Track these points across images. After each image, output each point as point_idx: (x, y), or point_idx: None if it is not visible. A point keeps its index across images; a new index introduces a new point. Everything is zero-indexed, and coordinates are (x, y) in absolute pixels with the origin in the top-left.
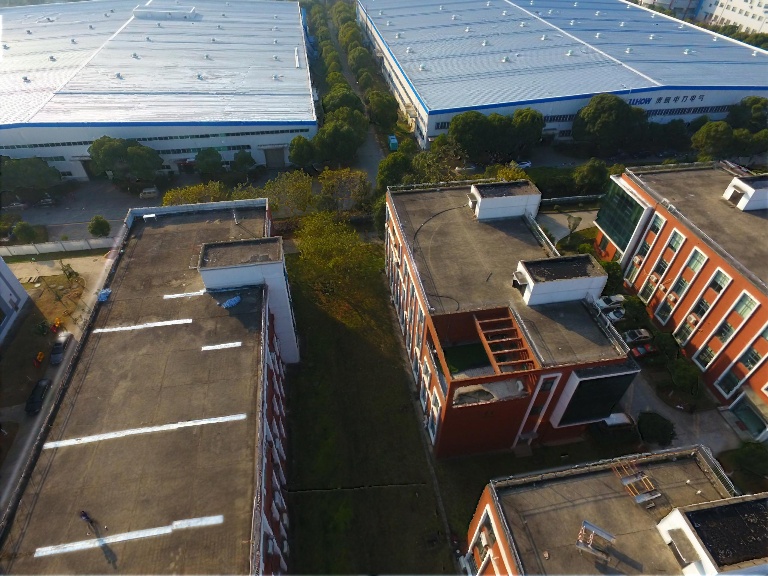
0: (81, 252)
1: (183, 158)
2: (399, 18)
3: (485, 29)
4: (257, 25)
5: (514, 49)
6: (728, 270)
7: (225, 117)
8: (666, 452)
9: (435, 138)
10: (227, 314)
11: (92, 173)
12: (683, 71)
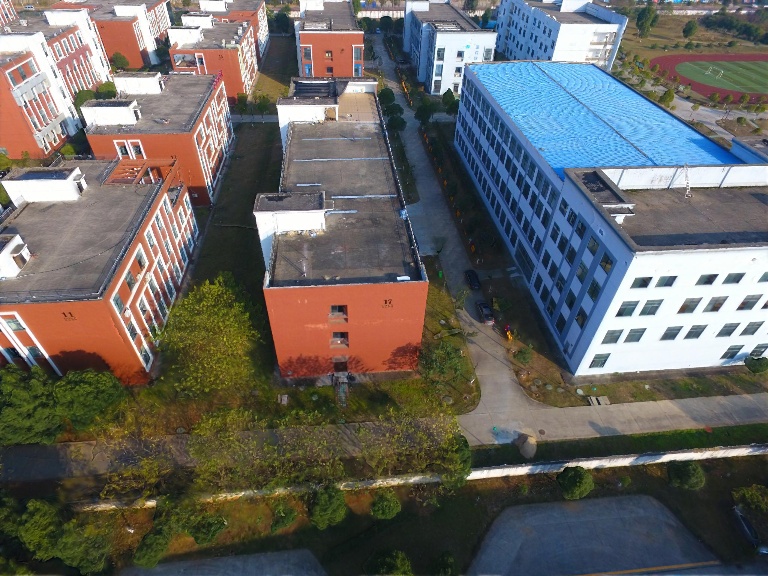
0: (579, 457)
1: None
2: None
3: None
4: None
5: None
6: None
7: None
8: None
9: None
10: None
11: None
12: None
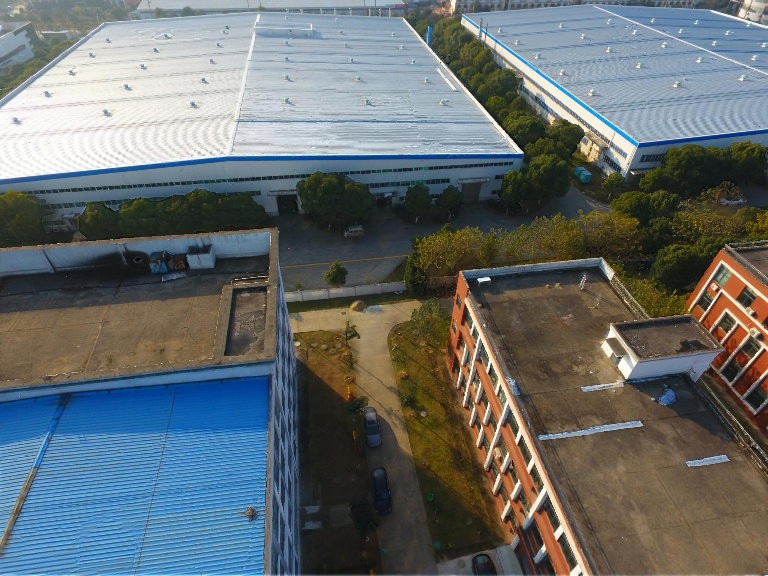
0: (321, 302)
1: (380, 192)
2: (523, 36)
3: (625, 50)
4: (381, 43)
5: (676, 73)
6: None
7: (427, 149)
8: None
9: (638, 171)
10: (675, 414)
11: (281, 207)
12: None
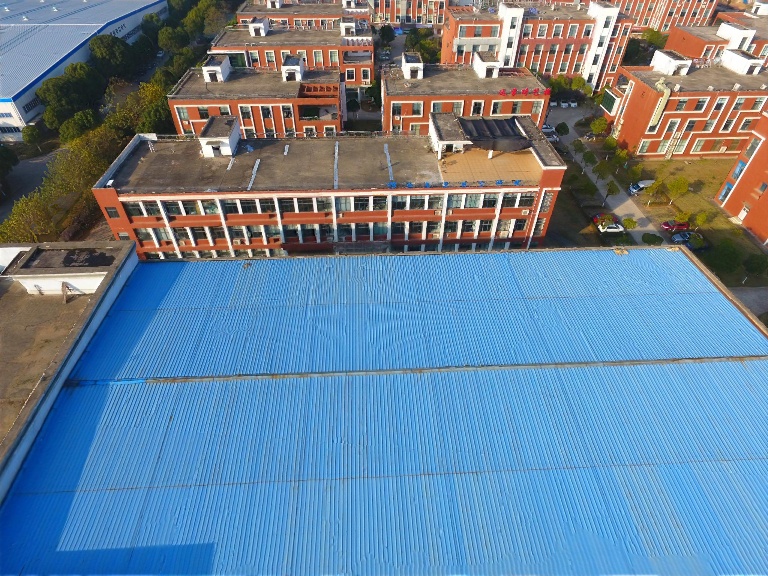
0: None
1: None
2: None
3: None
4: None
5: None
6: (301, 48)
7: None
8: (358, 117)
9: (33, 121)
10: (259, 149)
11: None
12: (87, 17)
